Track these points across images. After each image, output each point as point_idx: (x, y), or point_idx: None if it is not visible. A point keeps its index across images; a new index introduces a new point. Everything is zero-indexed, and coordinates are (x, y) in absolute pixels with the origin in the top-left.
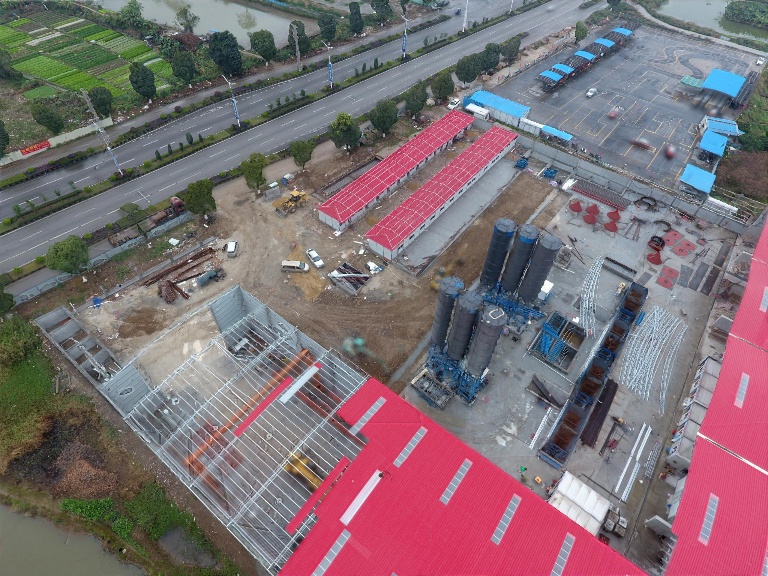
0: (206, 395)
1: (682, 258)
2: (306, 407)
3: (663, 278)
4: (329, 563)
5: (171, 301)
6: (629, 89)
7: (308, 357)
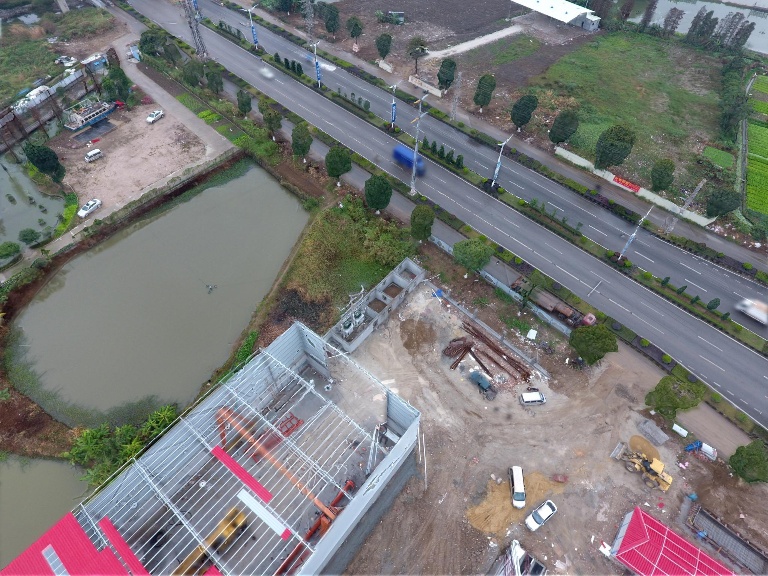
0: (333, 414)
1: None
2: (228, 523)
3: None
4: (54, 569)
5: (445, 353)
6: None
7: (327, 520)
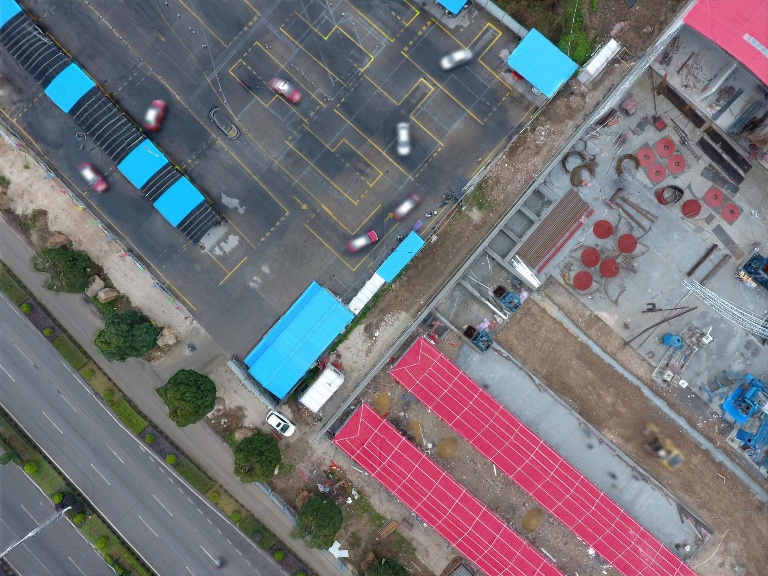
0: None
1: (690, 169)
2: None
3: (725, 213)
4: None
5: None
6: (203, 34)
7: None
